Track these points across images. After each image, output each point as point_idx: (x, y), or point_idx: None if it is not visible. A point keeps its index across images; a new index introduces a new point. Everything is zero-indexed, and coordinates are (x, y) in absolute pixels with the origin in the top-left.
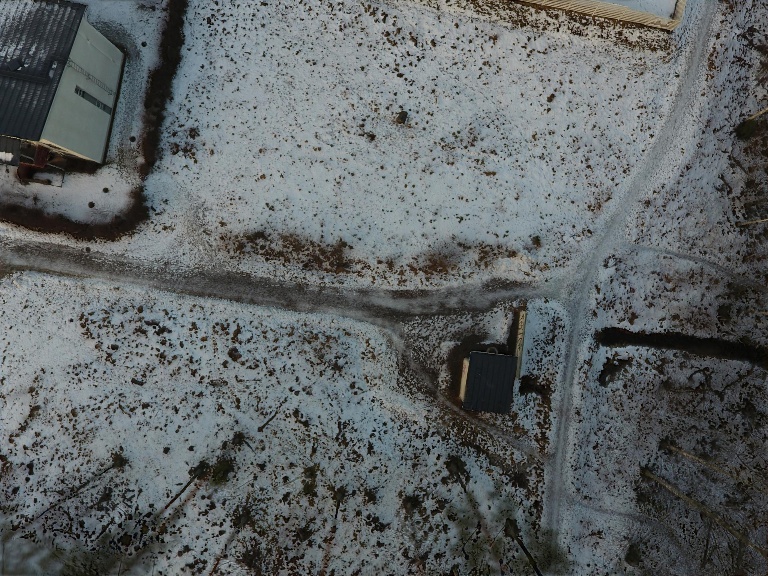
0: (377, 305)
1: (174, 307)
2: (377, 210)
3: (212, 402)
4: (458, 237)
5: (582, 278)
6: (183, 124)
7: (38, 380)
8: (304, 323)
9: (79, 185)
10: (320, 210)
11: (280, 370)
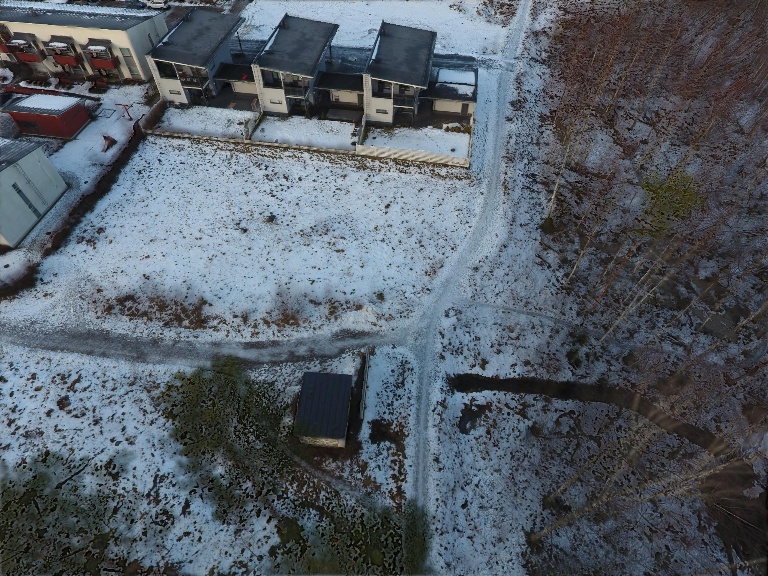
0: (227, 355)
1: (22, 360)
2: (240, 277)
3: (16, 456)
4: (309, 295)
5: (426, 326)
6: (95, 225)
7: None
8: (149, 374)
9: None
10: (190, 278)
11: (108, 419)
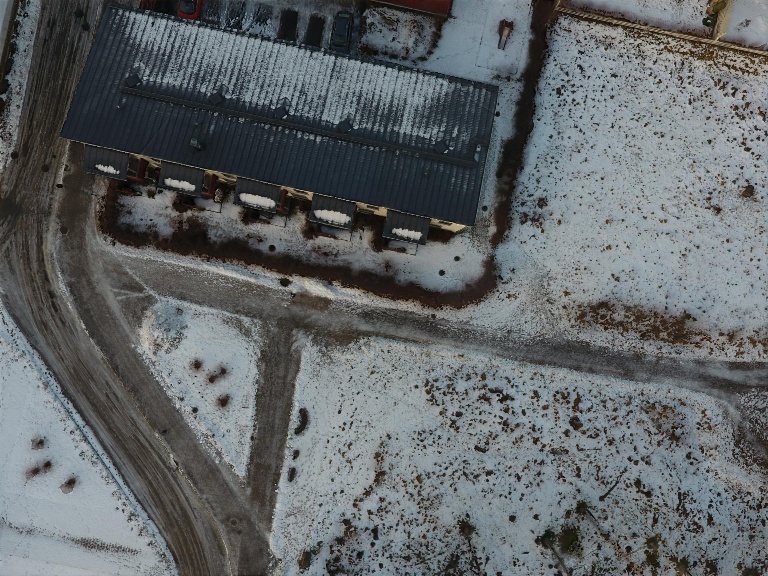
0: (713, 376)
1: (515, 375)
2: (722, 283)
3: (553, 470)
4: None
5: None
6: (532, 194)
7: (383, 446)
8: (641, 393)
9: (431, 253)
10: (665, 282)
11: (619, 439)
